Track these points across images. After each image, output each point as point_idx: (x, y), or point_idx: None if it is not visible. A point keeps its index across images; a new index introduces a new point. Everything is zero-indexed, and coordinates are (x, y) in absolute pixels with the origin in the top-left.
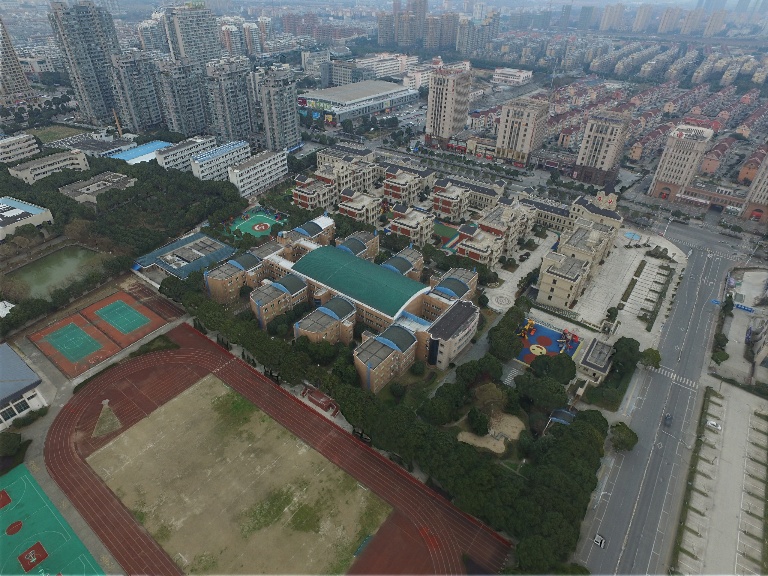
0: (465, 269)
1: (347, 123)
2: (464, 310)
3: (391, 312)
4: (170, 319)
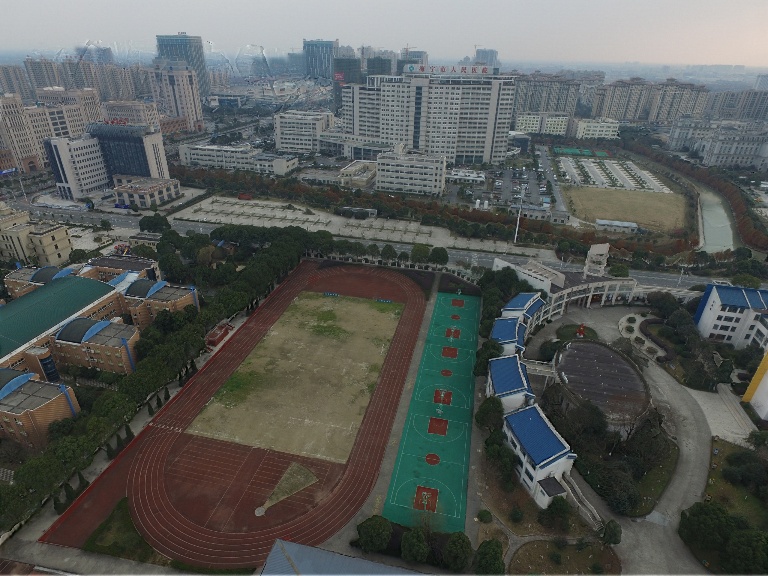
0: (11, 273)
1: None
2: (104, 262)
3: (107, 289)
4: (20, 574)
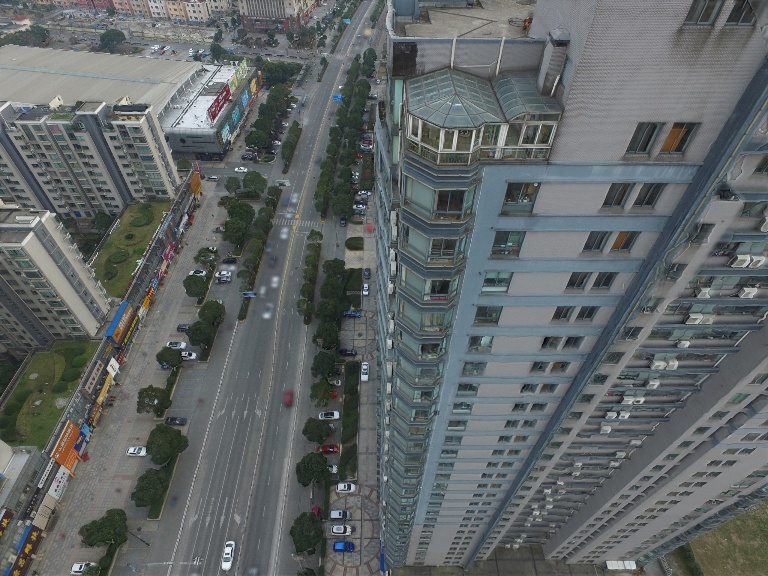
0: None
1: (284, 63)
2: None
3: None
4: None
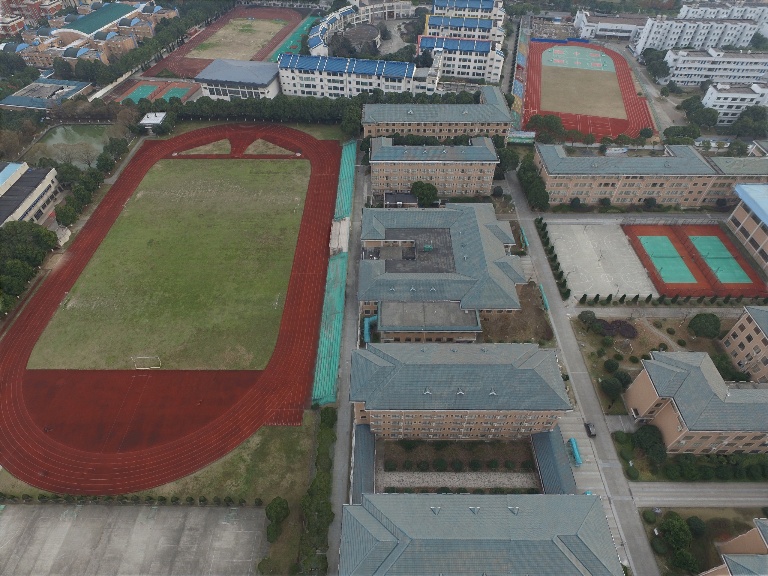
0: None
1: None
2: None
3: (133, 8)
4: (138, 81)
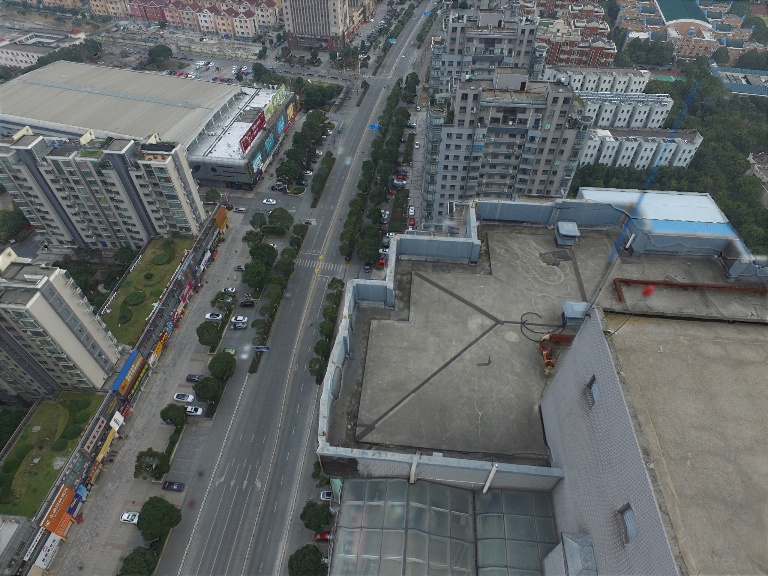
0: None
1: None
2: None
3: None
4: None
